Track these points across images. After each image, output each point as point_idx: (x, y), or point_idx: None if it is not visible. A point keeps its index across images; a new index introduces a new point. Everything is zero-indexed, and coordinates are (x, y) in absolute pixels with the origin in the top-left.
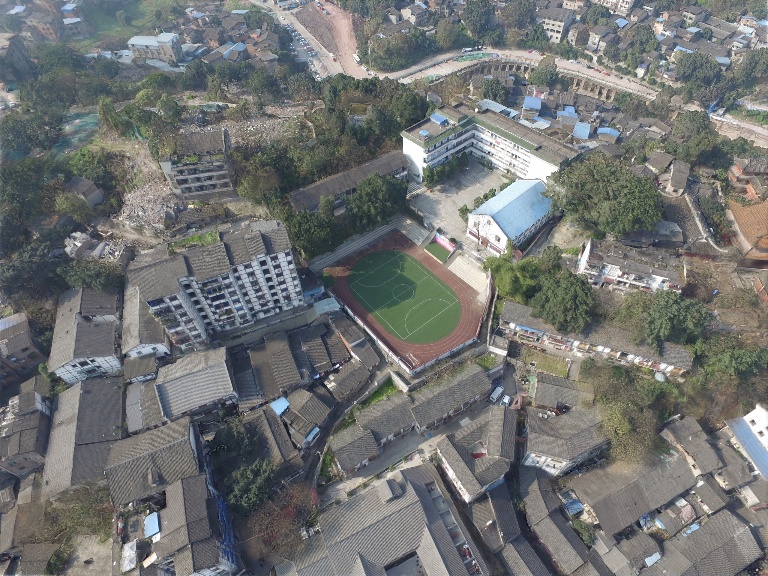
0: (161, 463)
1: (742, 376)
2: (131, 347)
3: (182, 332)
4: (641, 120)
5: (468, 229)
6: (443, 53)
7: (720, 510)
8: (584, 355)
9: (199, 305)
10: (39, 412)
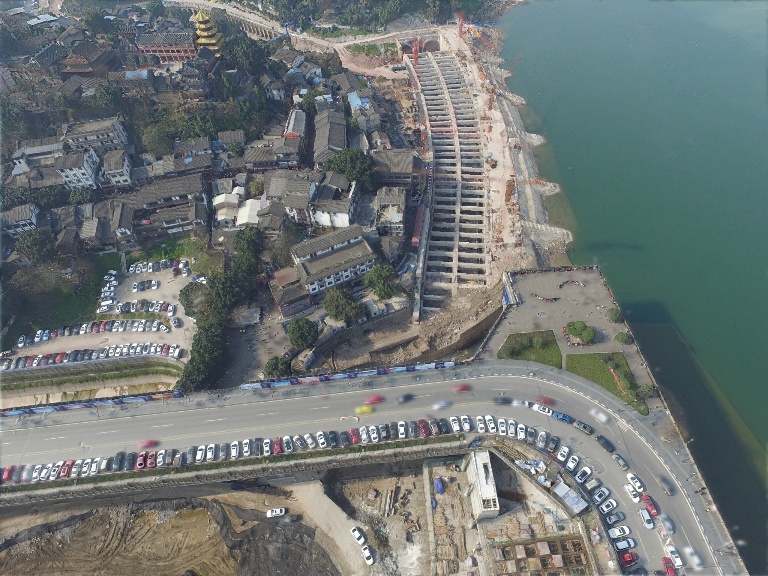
0: None
1: None
2: None
3: None
4: None
5: None
6: (136, 3)
7: None
8: None
9: None
10: None
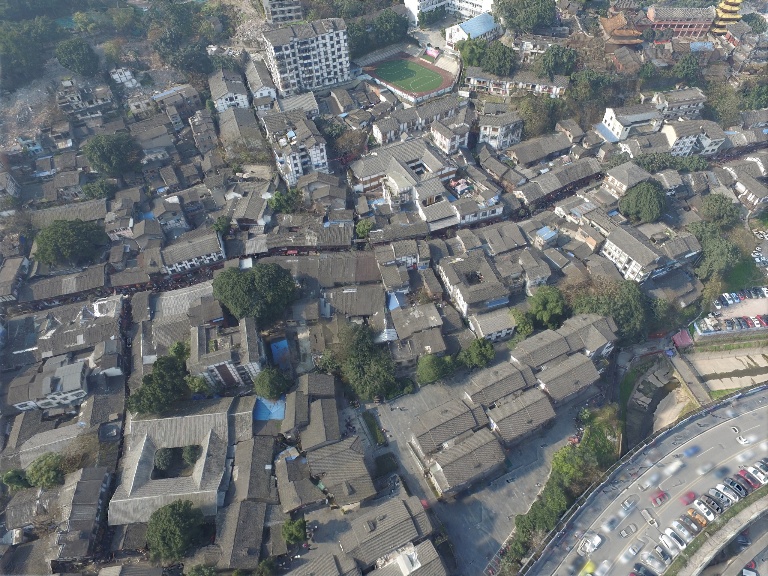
0: (290, 117)
1: (596, 90)
2: (258, 88)
3: (286, 79)
4: None
5: (446, 42)
6: None
7: (584, 157)
8: (513, 95)
9: (295, 64)
10: None
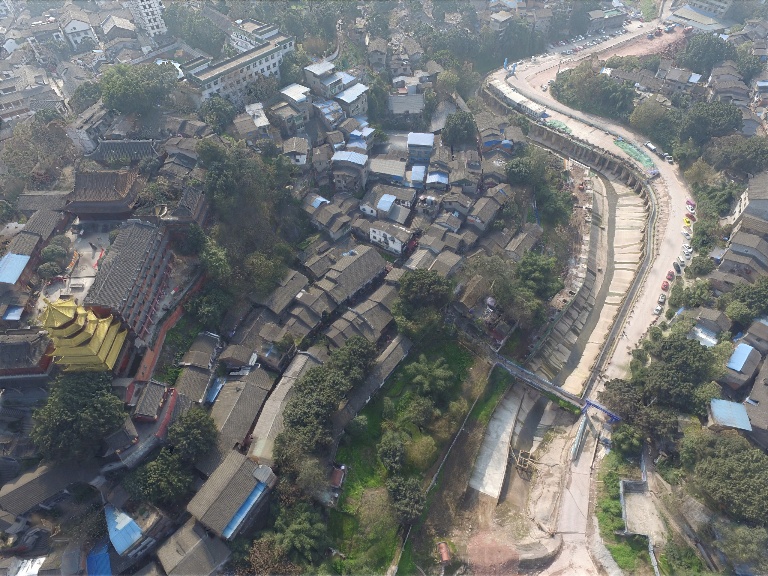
0: None
1: None
2: None
3: None
4: (452, 255)
5: None
6: (631, 130)
7: None
8: None
9: None
10: (123, 7)
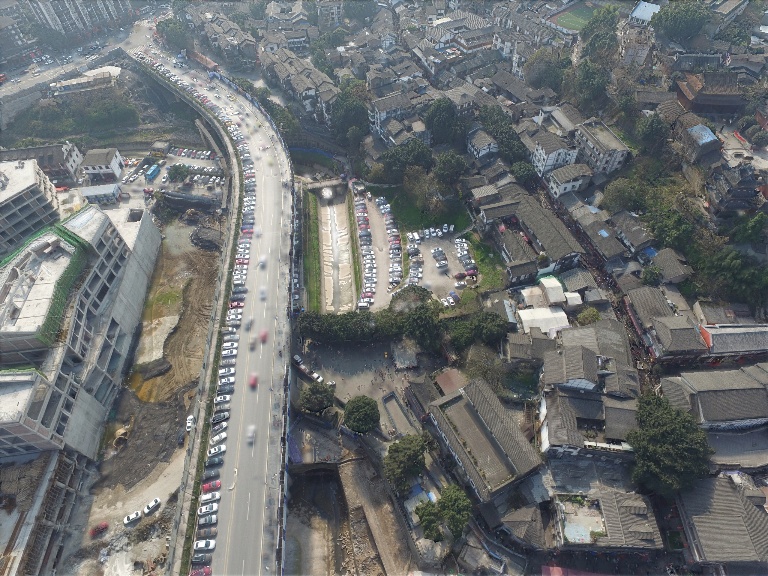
0: None
1: None
2: None
3: None
4: None
5: None
6: None
7: None
8: None
9: None
10: None
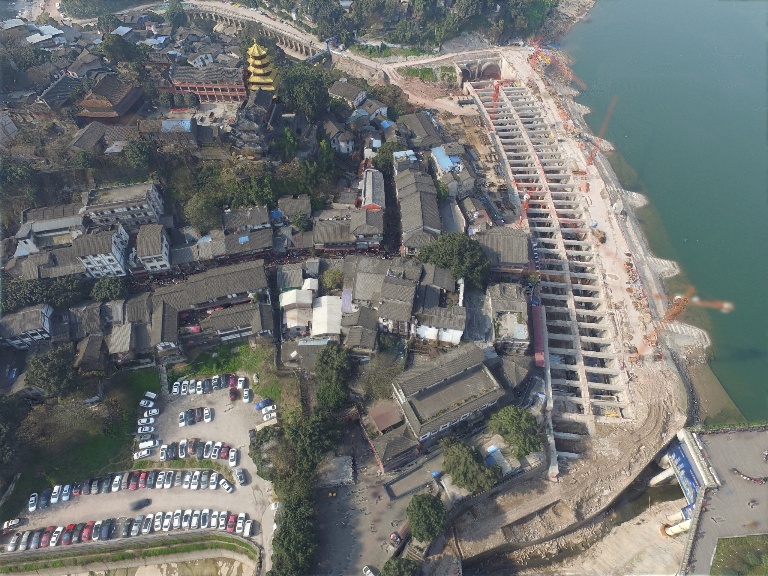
0: None
1: (7, 186)
2: None
3: None
4: (228, 48)
5: None
6: (147, 3)
7: None
8: None
9: None
10: None
